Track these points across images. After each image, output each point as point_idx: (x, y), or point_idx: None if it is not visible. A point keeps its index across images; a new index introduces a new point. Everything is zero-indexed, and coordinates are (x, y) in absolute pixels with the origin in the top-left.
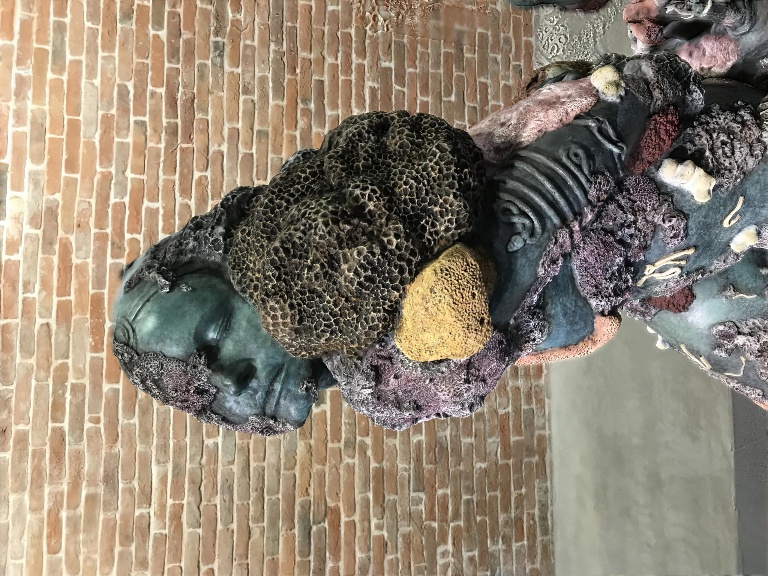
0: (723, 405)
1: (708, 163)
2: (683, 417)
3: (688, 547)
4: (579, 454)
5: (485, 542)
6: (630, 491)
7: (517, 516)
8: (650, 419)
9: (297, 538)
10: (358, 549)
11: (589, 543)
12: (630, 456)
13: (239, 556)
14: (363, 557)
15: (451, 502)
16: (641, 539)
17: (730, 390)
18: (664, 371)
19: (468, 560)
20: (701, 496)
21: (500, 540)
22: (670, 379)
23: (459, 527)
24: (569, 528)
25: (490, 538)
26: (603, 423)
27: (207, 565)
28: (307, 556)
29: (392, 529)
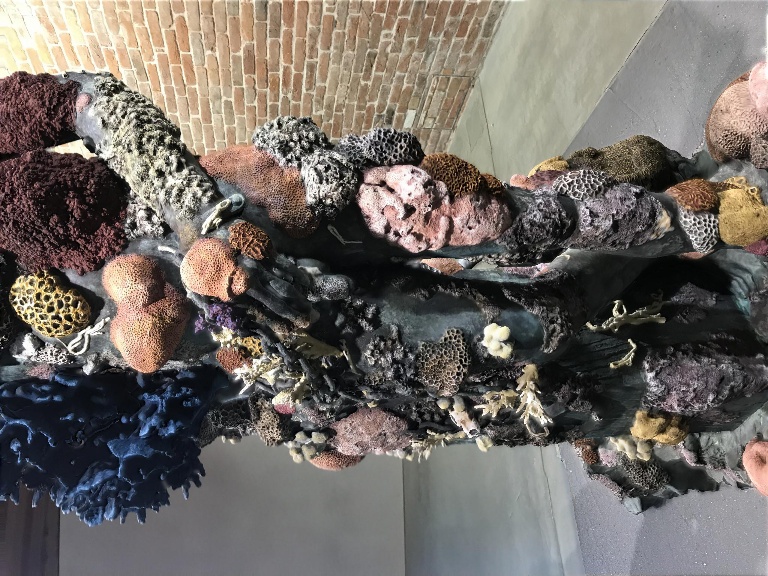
0: None
1: (240, 433)
2: (580, 80)
3: (536, 149)
4: (530, 7)
5: (427, 33)
6: (536, 77)
7: (465, 19)
8: (570, 50)
9: (255, 8)
10: (309, 22)
11: (504, 73)
12: (548, 56)
13: (205, 12)
14: (314, 28)
15: (403, 1)
16: (524, 111)
17: (576, 134)
18: (596, 31)
19: (408, 43)
20: (557, 135)
21: (442, 33)
22: (594, 43)
23: (405, 20)
24: (502, 47)
25: (433, 31)
26: (552, 6)
27: (178, 13)
28: (264, 20)
29: (342, 13)
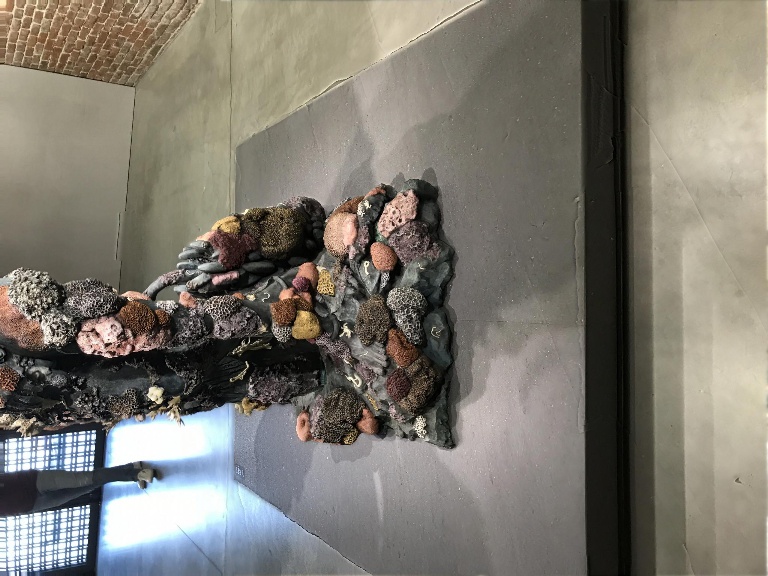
0: (307, 89)
1: None
2: (301, 54)
3: (263, 81)
4: None
5: None
6: (274, 16)
7: None
8: (300, 19)
9: None
10: None
11: None
12: (285, 7)
13: None
14: None
15: None
16: None
17: (282, 119)
18: (318, 23)
19: None
20: (279, 84)
21: None
22: (315, 32)
23: None
24: None
25: None
26: None
27: None
28: None
29: None
